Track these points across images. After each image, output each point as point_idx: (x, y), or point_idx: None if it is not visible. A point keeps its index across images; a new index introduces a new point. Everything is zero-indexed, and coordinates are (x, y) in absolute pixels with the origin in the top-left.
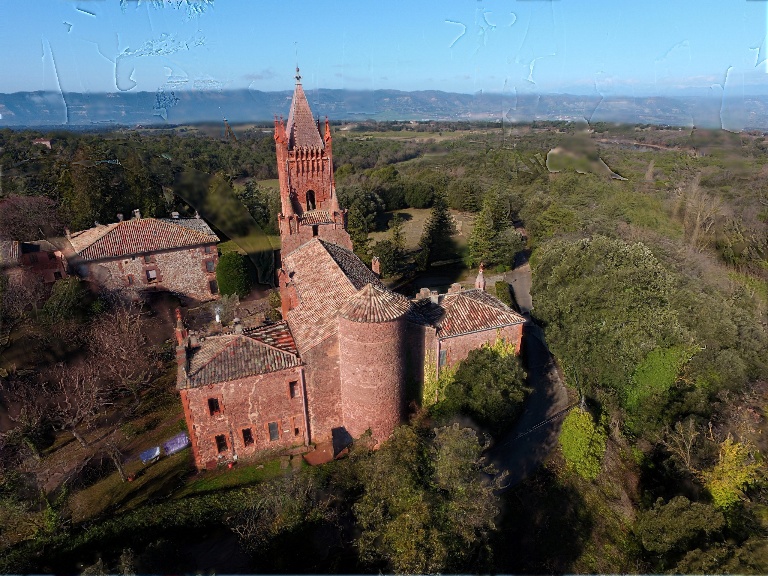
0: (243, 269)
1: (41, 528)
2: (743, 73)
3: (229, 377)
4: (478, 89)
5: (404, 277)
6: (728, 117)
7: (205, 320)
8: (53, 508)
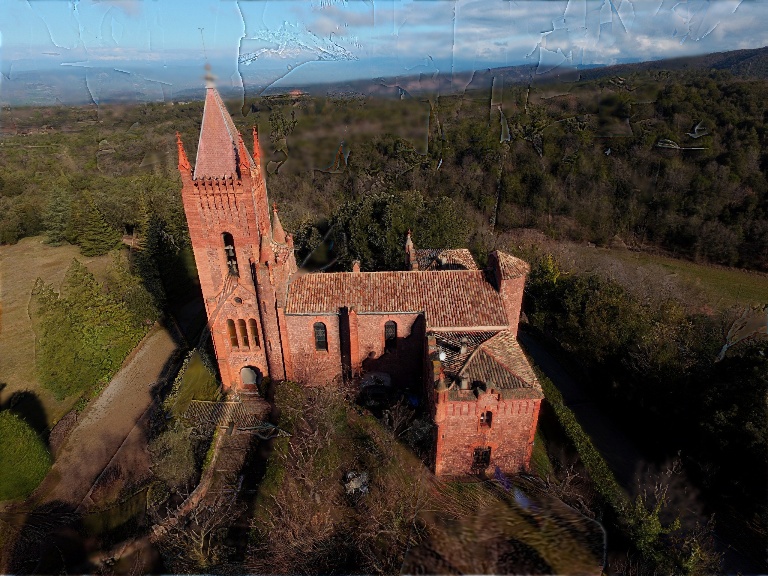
0: (27, 427)
1: (659, 537)
2: None
3: (529, 367)
4: (14, 75)
5: (160, 321)
6: None
7: None
8: None
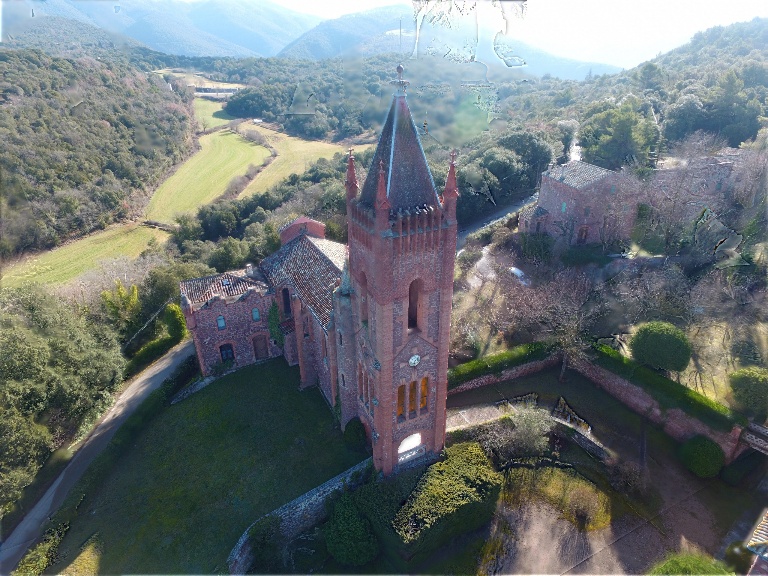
0: None
1: None
2: None
3: None
4: None
5: None
6: None
7: (626, 521)
8: None
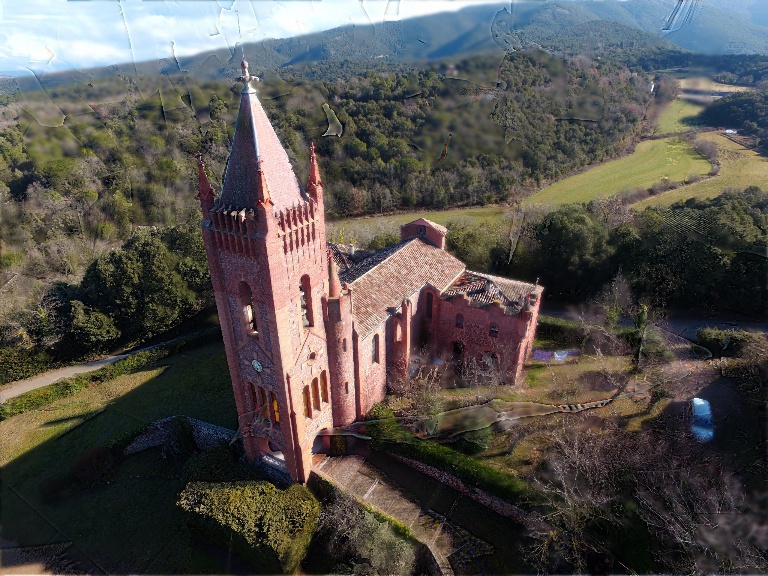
0: None
1: None
2: (31, 73)
3: None
4: None
5: None
6: (40, 114)
7: None
8: (612, 310)
